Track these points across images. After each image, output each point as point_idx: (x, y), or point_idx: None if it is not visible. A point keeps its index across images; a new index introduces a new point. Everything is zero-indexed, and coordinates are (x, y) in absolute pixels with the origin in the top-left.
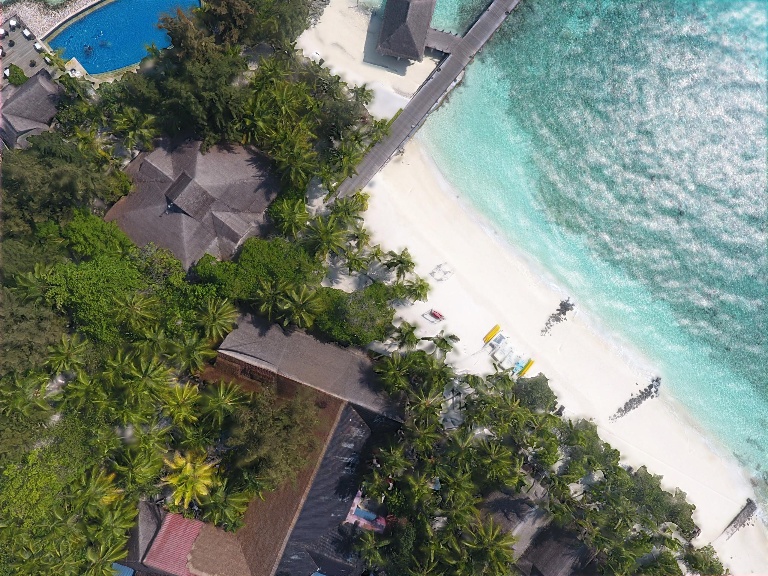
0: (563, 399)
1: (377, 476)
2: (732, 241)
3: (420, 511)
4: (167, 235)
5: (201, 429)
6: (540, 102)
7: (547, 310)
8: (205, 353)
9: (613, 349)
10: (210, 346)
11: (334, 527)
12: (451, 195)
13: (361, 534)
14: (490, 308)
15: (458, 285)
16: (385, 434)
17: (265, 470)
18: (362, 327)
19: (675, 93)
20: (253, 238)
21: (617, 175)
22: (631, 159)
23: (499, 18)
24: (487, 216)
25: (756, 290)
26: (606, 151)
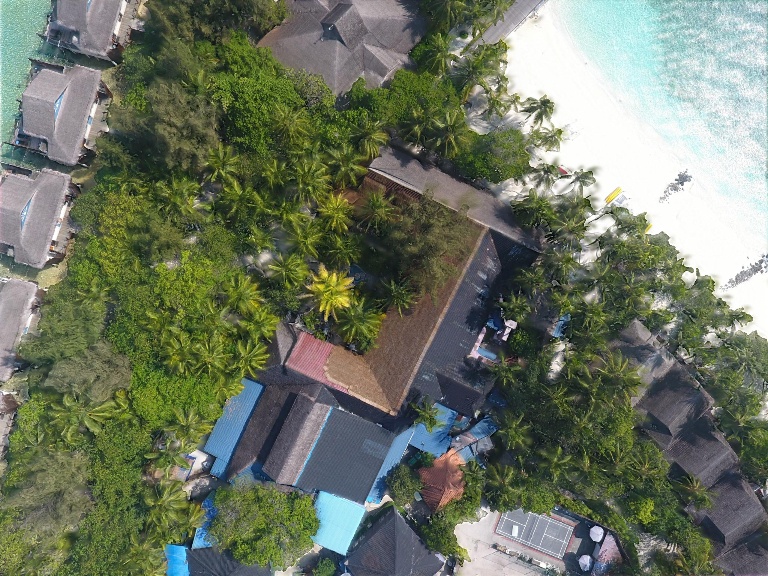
0: None
1: (515, 299)
2: None
3: (539, 356)
4: (319, 63)
5: (349, 240)
6: None
7: (666, 179)
8: (358, 168)
9: (727, 222)
10: (361, 163)
11: (460, 358)
12: (580, 61)
13: (485, 368)
14: (613, 171)
15: (584, 146)
16: (516, 271)
17: (410, 282)
18: (506, 159)
19: None
20: (403, 70)
21: (739, 56)
22: (753, 42)
23: None
24: (613, 85)
25: None
26: (729, 33)
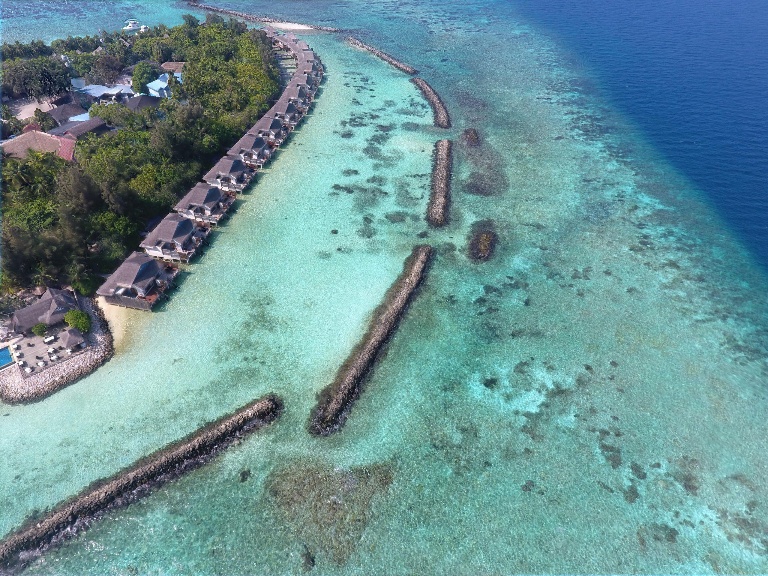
0: None
1: None
2: None
3: None
4: None
5: None
6: None
7: None
8: None
9: None
10: None
11: None
12: None
13: None
14: None
15: None
16: None
17: None
18: None
19: None
20: None
21: None
22: None
23: None
24: None
25: None
26: None
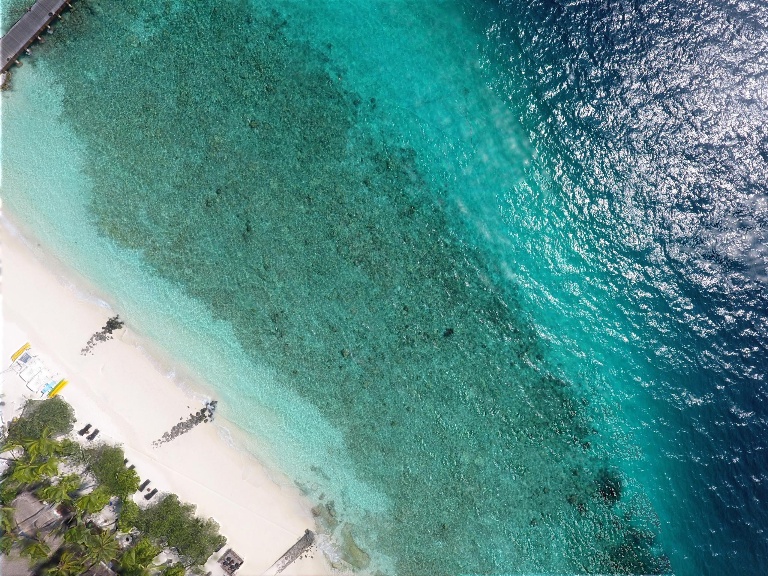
0: (99, 422)
1: None
2: (304, 259)
3: None
4: None
5: None
6: (97, 109)
7: (91, 328)
8: None
9: (164, 370)
10: None
11: None
12: None
13: None
14: (22, 325)
15: None
16: None
17: None
18: None
19: (248, 103)
20: None
21: (179, 187)
22: (196, 171)
23: (42, 19)
24: (31, 228)
25: (329, 311)
26: (168, 162)
